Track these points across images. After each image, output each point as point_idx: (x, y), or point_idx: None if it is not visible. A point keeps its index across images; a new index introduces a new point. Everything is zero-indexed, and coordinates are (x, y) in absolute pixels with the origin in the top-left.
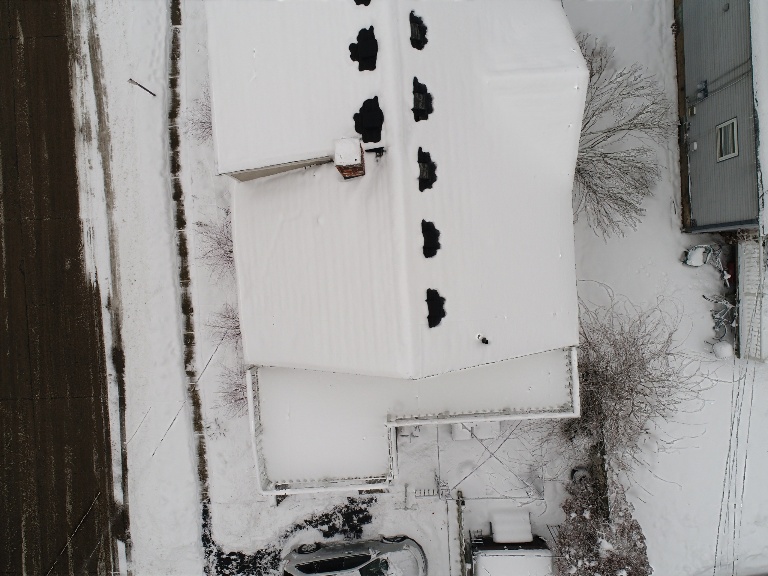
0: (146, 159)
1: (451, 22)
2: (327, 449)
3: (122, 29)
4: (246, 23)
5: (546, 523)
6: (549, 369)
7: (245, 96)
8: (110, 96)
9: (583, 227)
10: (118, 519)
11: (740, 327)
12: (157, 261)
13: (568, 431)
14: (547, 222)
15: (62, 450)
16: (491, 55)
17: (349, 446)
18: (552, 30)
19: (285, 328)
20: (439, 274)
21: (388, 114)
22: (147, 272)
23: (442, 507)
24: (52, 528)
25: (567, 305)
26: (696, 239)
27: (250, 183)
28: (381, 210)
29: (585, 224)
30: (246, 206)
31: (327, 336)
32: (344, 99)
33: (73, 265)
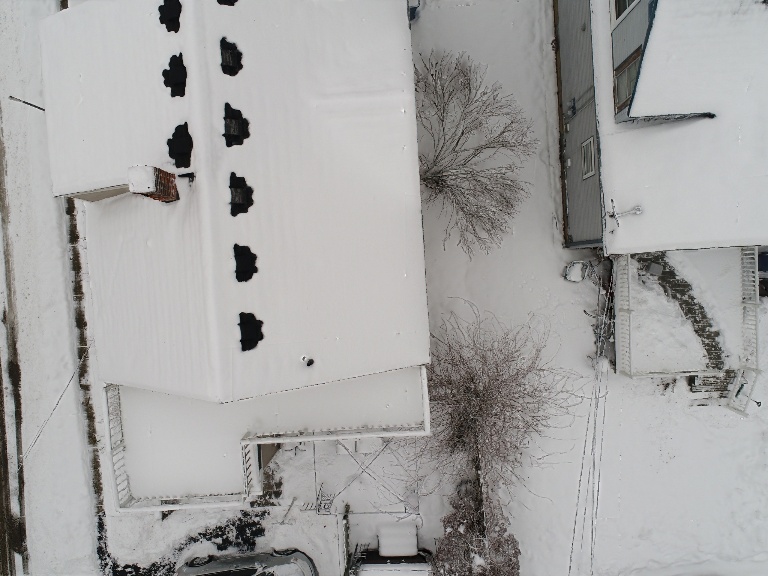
0: (37, 174)
1: (271, 47)
2: (188, 466)
3: (15, 45)
4: (73, 48)
5: (434, 536)
6: (406, 387)
7: (74, 120)
8: (4, 111)
9: None
10: (15, 532)
11: (616, 342)
12: (49, 275)
13: (440, 447)
14: (389, 242)
15: None
16: (321, 78)
17: (210, 463)
18: (389, 53)
19: (127, 348)
20: (255, 298)
21: (196, 140)
22: (40, 286)
23: (333, 520)
24: None
25: (414, 324)
26: (577, 254)
27: (99, 203)
28: (193, 235)
29: None
30: (95, 226)
31: (157, 357)
32: (158, 125)
33: None
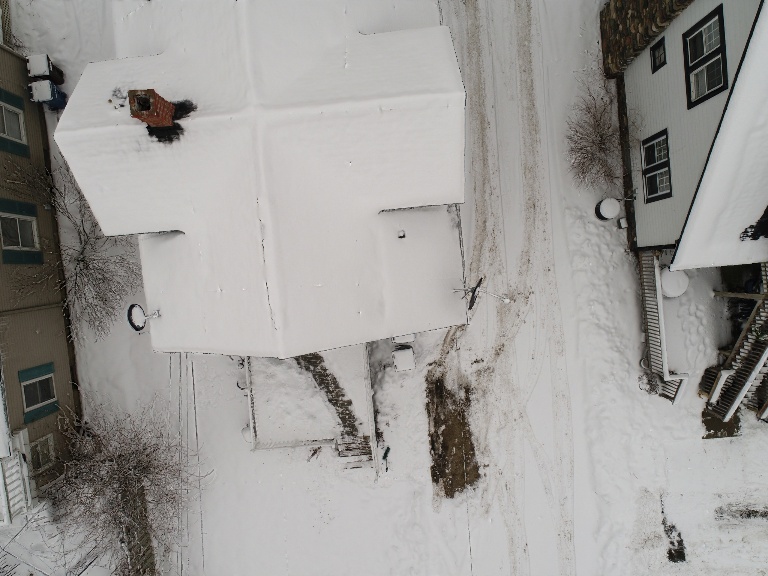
0: None
1: None
2: None
3: None
4: None
5: None
6: None
7: None
8: None
9: None
10: None
11: None
12: None
13: (77, 523)
14: None
15: None
16: None
17: None
18: None
19: None
20: None
21: None
22: None
23: None
24: None
25: None
26: None
27: None
28: None
29: None
30: None
31: None
32: None
33: None
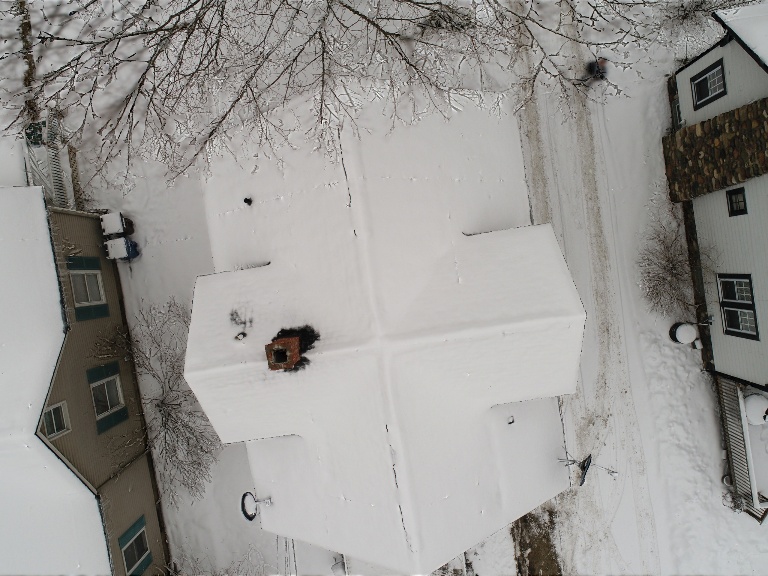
0: None
1: None
2: None
3: None
4: None
5: None
6: None
7: None
8: None
9: None
10: None
11: None
12: None
13: None
14: (55, 542)
15: None
16: None
17: None
18: (28, 375)
19: None
20: None
21: None
22: None
23: None
24: None
25: None
26: None
27: None
28: None
29: None
30: None
31: None
32: None
33: None
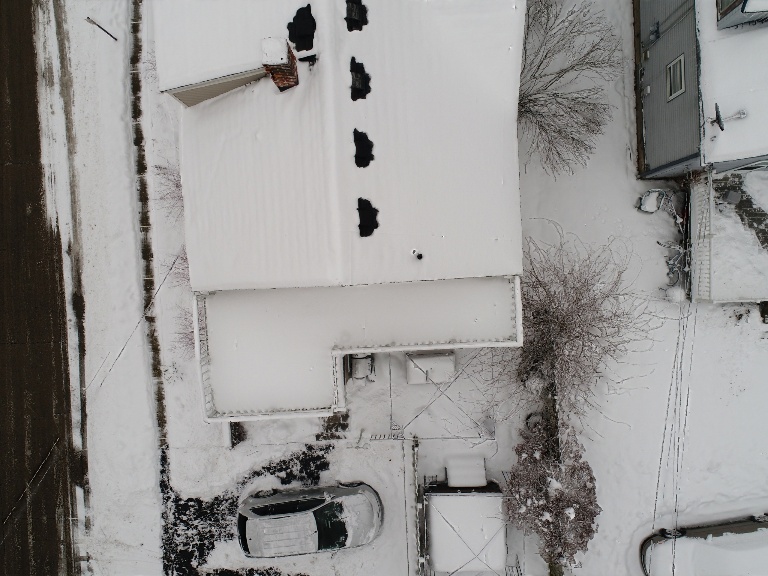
0: (107, 103)
1: None
2: (274, 380)
3: None
4: None
5: (501, 469)
6: (495, 301)
7: (185, 11)
8: (72, 41)
9: (540, 173)
10: (77, 465)
11: (692, 271)
12: (117, 205)
13: (518, 370)
14: (489, 148)
15: (21, 395)
16: None
17: (296, 377)
18: None
19: (227, 249)
20: (372, 185)
21: (320, 21)
22: (107, 216)
23: (399, 454)
24: (11, 474)
25: (510, 232)
26: (651, 186)
27: (196, 107)
28: (313, 118)
29: (542, 170)
30: (192, 131)
31: (264, 252)
32: (278, 8)
33: (34, 210)
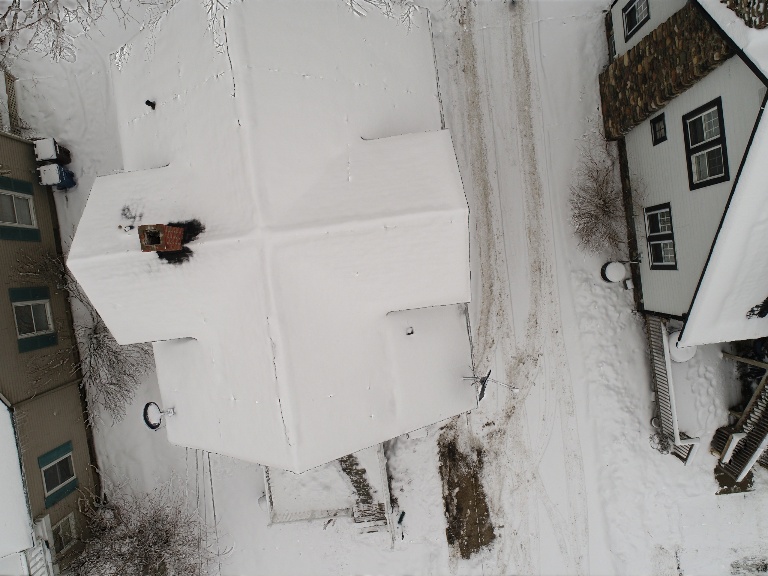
0: None
1: None
2: None
3: None
4: None
5: None
6: None
7: None
8: None
9: (144, 391)
10: None
11: None
12: None
13: None
14: None
15: None
16: None
17: None
18: None
19: None
20: None
21: None
22: None
23: None
24: None
25: (2, 518)
26: None
27: None
28: None
29: (145, 388)
30: None
31: None
32: None
33: None
